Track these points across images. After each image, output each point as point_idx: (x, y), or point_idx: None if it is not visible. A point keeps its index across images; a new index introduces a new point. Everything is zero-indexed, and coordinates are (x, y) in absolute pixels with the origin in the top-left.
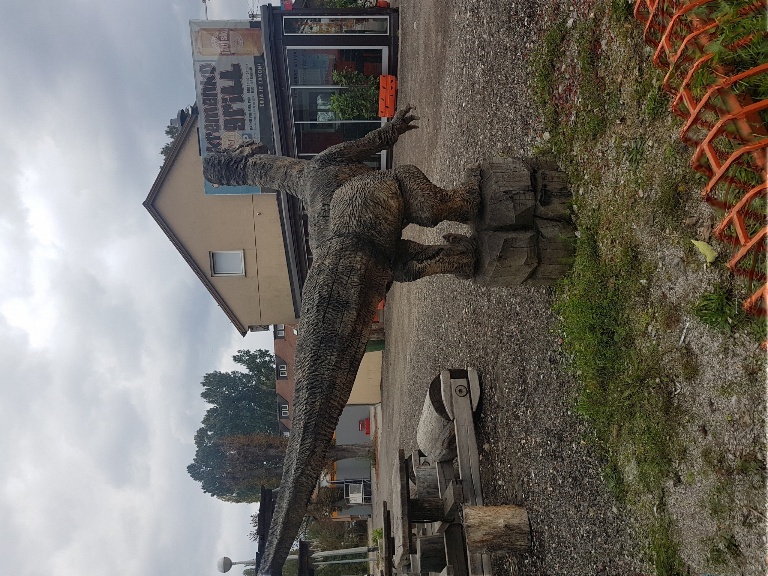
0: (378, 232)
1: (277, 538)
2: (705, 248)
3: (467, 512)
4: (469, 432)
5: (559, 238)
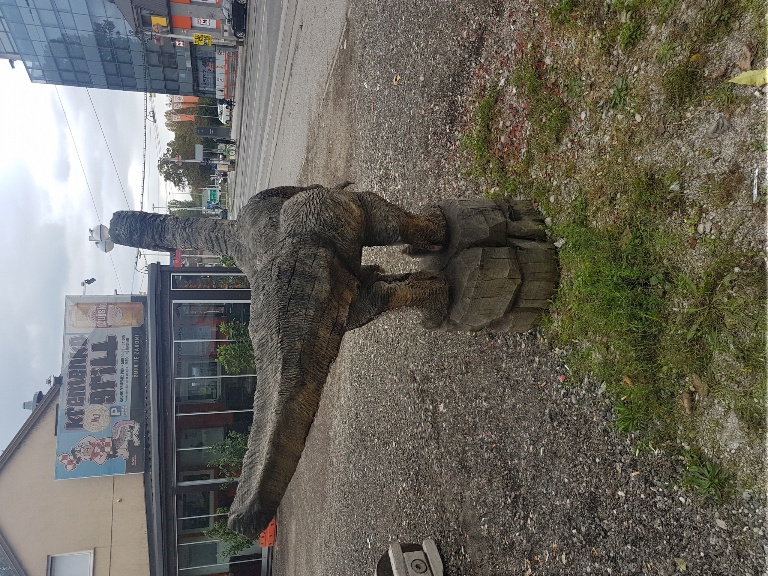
0: (340, 234)
1: None
2: (751, 73)
3: None
4: None
5: (539, 249)
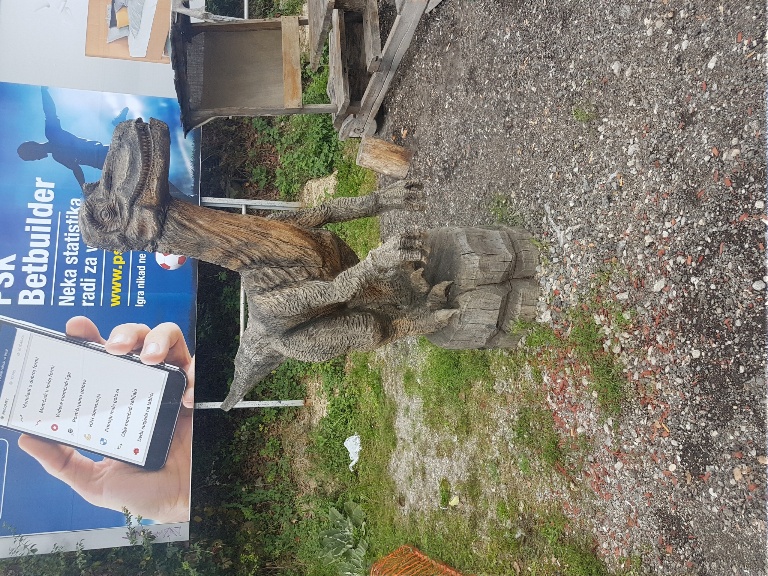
0: None
1: None
2: (457, 501)
3: (363, 158)
4: (410, 29)
5: None
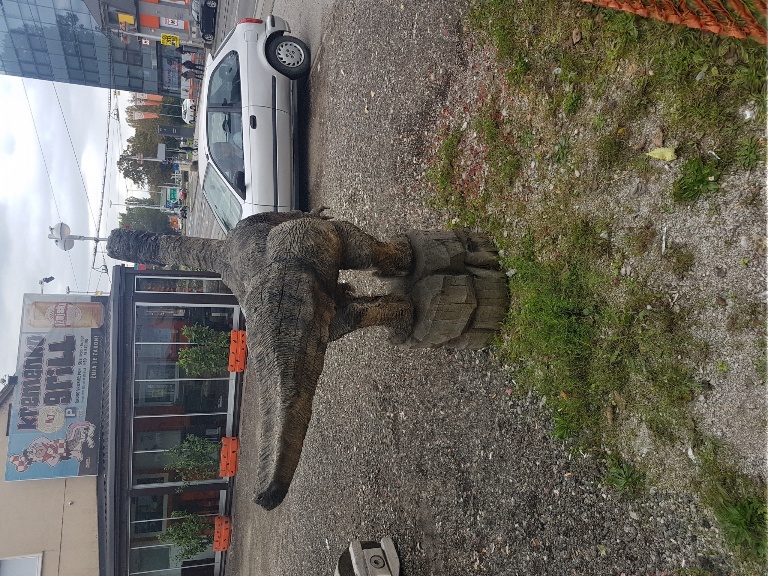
0: (320, 262)
1: (275, 457)
2: (663, 150)
3: None
4: None
5: (493, 278)
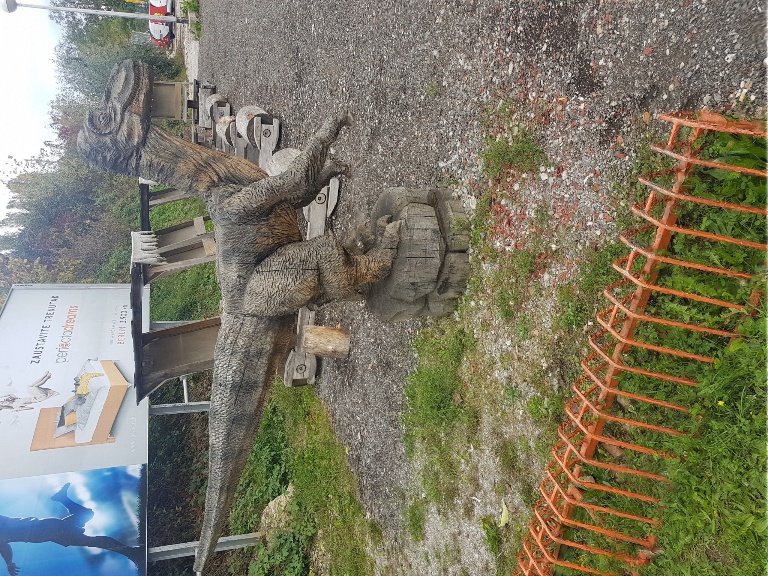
0: None
1: (204, 558)
2: (505, 512)
3: (307, 337)
4: None
5: (441, 312)
